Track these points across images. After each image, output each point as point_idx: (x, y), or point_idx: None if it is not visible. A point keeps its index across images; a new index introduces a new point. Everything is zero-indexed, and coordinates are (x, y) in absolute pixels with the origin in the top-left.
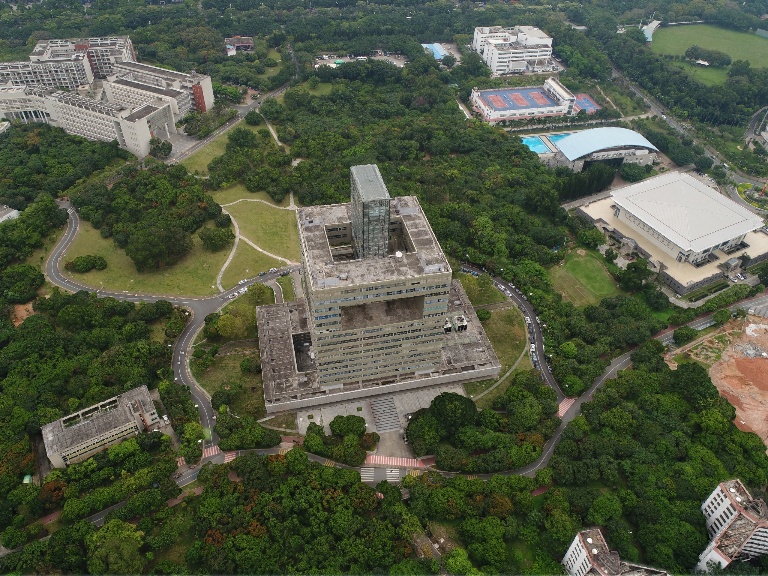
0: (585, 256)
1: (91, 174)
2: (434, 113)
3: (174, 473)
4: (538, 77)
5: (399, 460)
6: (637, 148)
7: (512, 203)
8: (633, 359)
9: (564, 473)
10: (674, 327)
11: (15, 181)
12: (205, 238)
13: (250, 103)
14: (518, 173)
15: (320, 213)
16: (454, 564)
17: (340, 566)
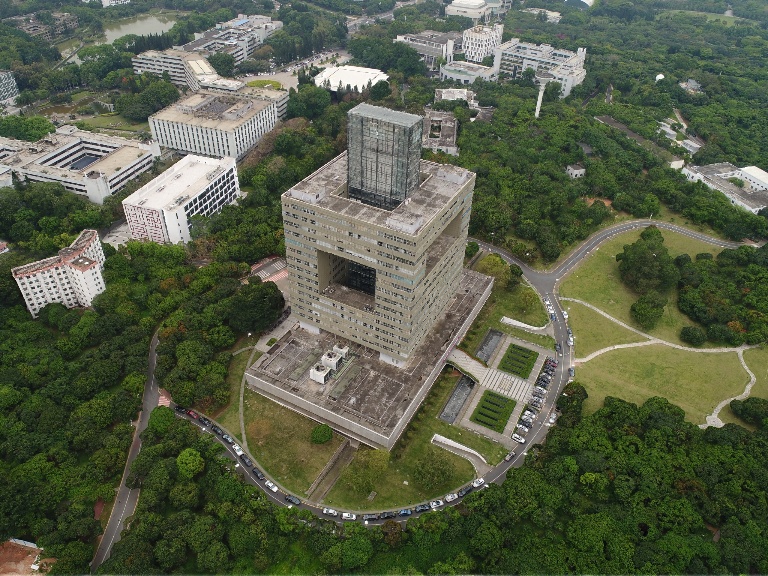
0: None
1: None
2: None
3: None
4: None
5: None
6: None
7: None
8: None
9: None
10: None
11: None
12: None
13: None
14: None
15: (448, 174)
16: (178, 245)
17: None
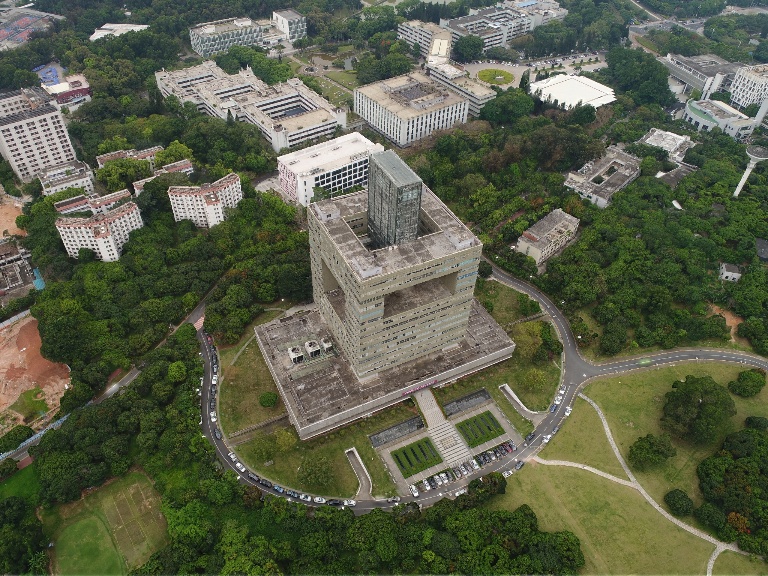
0: None
1: None
2: None
3: None
4: None
5: None
6: None
7: None
8: None
9: None
10: None
11: None
12: None
13: None
14: None
15: (453, 236)
16: None
17: None
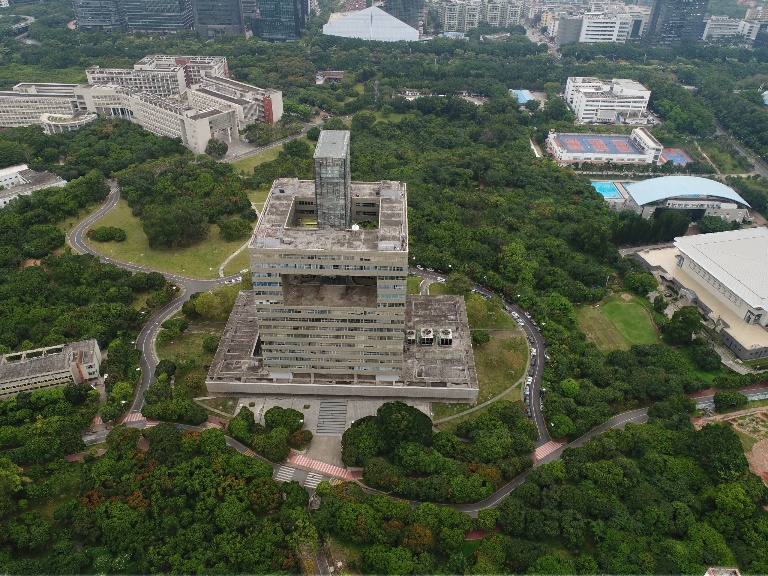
0: (629, 301)
1: (145, 161)
2: (501, 149)
3: (89, 430)
4: (628, 128)
5: (327, 466)
6: (723, 200)
7: (557, 237)
8: (650, 412)
9: (512, 519)
10: (720, 391)
11: (78, 159)
12: (222, 226)
13: (319, 123)
14: (573, 210)
15: (295, 185)
16: None
17: (207, 561)
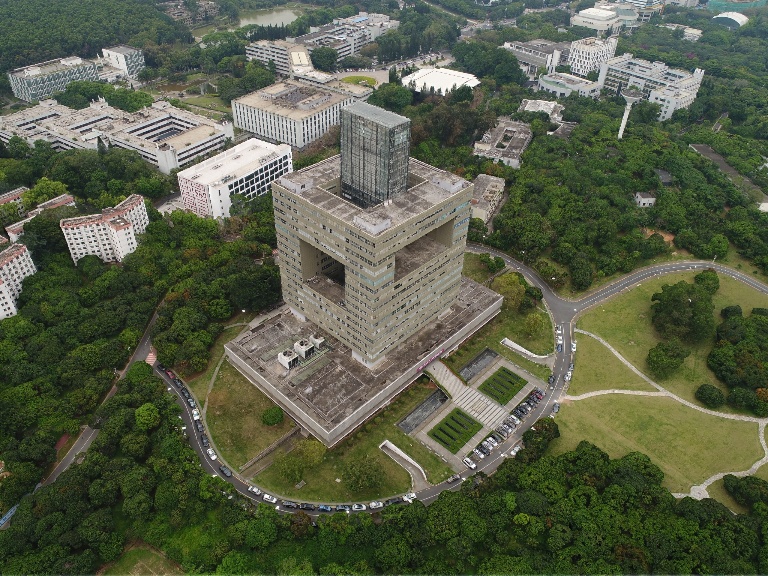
0: None
1: None
2: None
3: None
4: None
5: None
6: None
7: None
8: None
9: None
10: None
11: None
12: None
13: None
14: None
15: (442, 181)
16: None
17: None
